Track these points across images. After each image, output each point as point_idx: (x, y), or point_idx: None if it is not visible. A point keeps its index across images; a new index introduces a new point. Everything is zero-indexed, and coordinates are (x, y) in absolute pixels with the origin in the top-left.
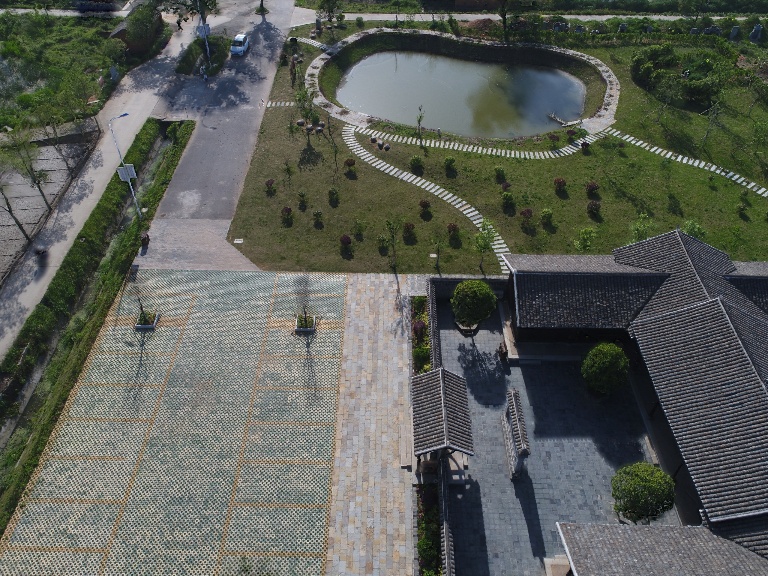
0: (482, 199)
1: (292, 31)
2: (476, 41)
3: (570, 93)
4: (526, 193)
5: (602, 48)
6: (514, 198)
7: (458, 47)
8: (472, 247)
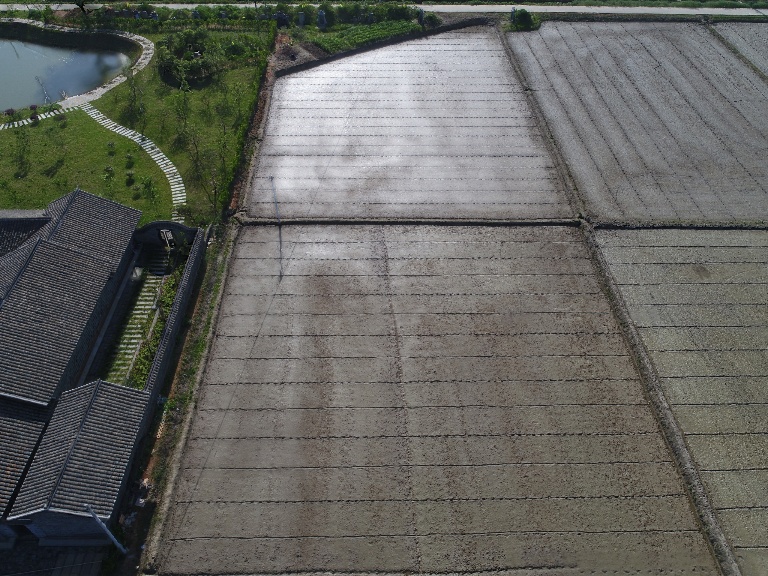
0: None
1: None
2: (58, 28)
3: (106, 74)
4: None
5: (166, 33)
6: None
7: (41, 34)
8: None
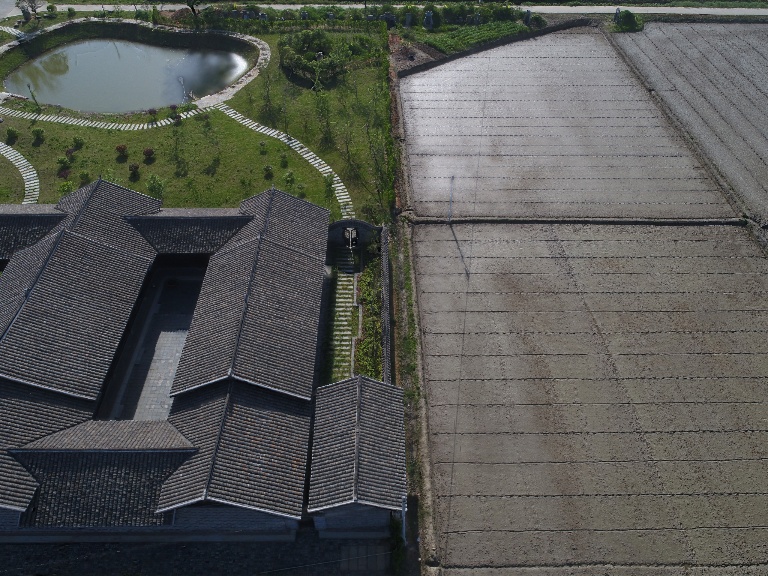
0: (48, 164)
1: (3, 21)
2: (168, 29)
3: (226, 74)
4: (88, 158)
5: (277, 34)
6: (74, 162)
7: (151, 34)
8: (4, 203)
